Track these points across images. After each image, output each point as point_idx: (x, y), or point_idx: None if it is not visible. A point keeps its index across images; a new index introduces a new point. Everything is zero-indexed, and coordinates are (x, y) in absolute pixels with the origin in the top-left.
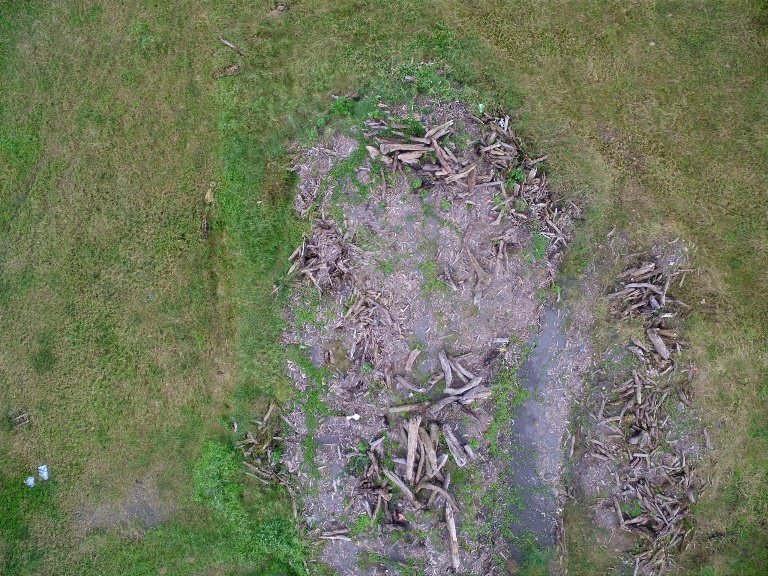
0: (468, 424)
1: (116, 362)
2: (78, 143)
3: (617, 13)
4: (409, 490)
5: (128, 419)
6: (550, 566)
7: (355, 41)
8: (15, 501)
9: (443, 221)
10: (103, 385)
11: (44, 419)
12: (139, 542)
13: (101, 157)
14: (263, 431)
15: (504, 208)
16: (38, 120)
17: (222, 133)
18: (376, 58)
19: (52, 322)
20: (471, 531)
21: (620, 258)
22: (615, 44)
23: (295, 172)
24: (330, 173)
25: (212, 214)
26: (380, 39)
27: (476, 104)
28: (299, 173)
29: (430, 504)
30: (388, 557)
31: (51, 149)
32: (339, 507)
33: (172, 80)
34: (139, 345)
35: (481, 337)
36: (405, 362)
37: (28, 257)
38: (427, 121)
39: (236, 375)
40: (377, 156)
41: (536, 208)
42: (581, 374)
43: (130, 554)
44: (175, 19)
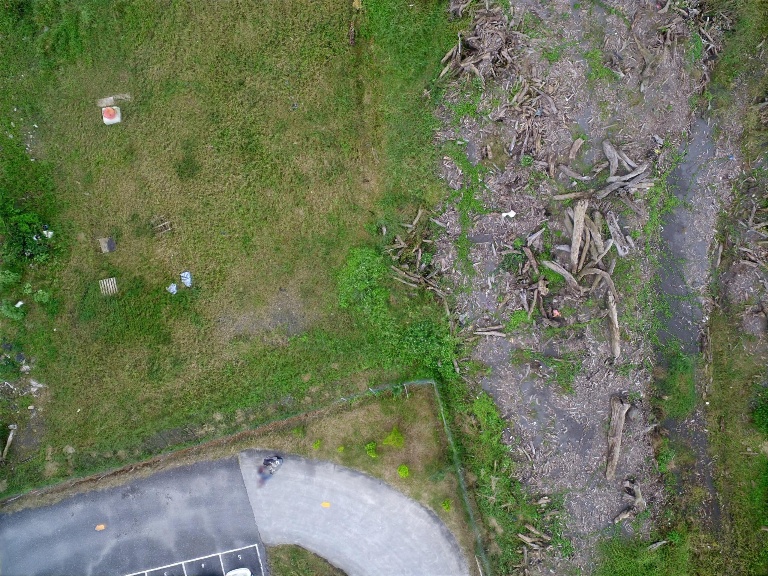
0: (629, 215)
1: (261, 169)
2: None
3: None
4: (572, 277)
5: (273, 226)
6: (695, 374)
7: None
8: (158, 307)
9: (611, 8)
10: (247, 192)
11: (187, 226)
12: (283, 348)
13: None
14: (412, 234)
15: None
16: None
17: None
18: None
19: (196, 129)
20: (631, 321)
21: None
22: None
23: None
24: None
25: (359, 22)
26: None
27: None
28: None
29: (591, 293)
30: (542, 353)
31: None
32: (493, 304)
33: None
34: (284, 152)
35: (646, 126)
36: (568, 151)
37: (172, 64)
38: None
39: (383, 182)
40: None
41: None
42: (731, 182)
43: (275, 359)
44: None
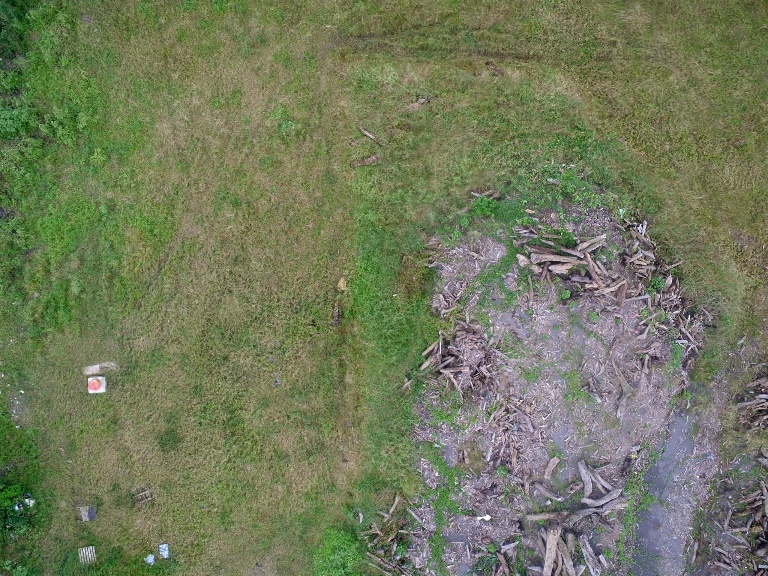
0: (603, 534)
1: (242, 445)
2: (212, 224)
3: (756, 122)
4: None
5: (251, 502)
6: None
7: (494, 137)
8: None
9: (589, 332)
10: (228, 467)
11: (167, 498)
12: None
13: (235, 240)
14: (389, 523)
15: (652, 323)
16: (173, 199)
17: (358, 223)
18: (514, 155)
19: (179, 401)
20: None
21: (750, 367)
22: (752, 153)
23: (433, 268)
24: (478, 278)
25: (343, 302)
26: (519, 137)
27: (617, 210)
28: (440, 272)
29: None
30: None
31: (185, 229)
32: None
33: (309, 166)
34: (265, 429)
35: (621, 449)
36: (544, 469)
37: (158, 335)
38: (577, 231)
39: (361, 464)
40: (527, 265)
41: (671, 315)
42: (708, 482)
43: None
44: (314, 106)
